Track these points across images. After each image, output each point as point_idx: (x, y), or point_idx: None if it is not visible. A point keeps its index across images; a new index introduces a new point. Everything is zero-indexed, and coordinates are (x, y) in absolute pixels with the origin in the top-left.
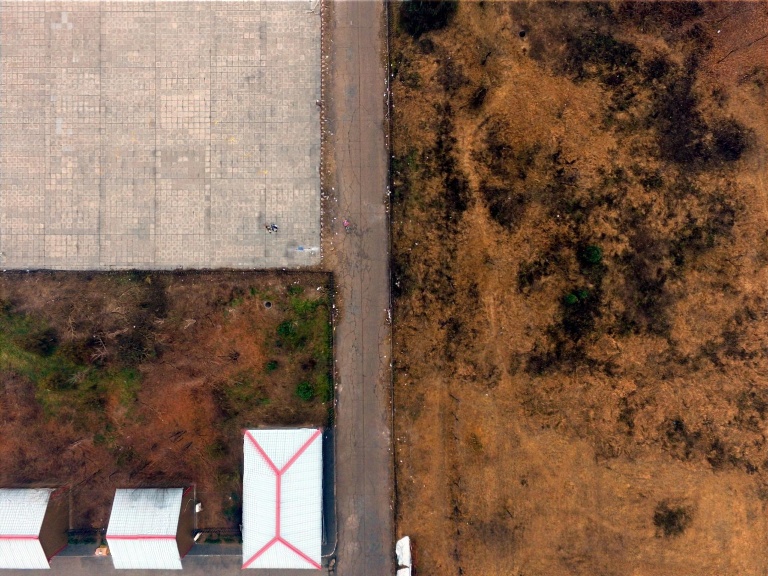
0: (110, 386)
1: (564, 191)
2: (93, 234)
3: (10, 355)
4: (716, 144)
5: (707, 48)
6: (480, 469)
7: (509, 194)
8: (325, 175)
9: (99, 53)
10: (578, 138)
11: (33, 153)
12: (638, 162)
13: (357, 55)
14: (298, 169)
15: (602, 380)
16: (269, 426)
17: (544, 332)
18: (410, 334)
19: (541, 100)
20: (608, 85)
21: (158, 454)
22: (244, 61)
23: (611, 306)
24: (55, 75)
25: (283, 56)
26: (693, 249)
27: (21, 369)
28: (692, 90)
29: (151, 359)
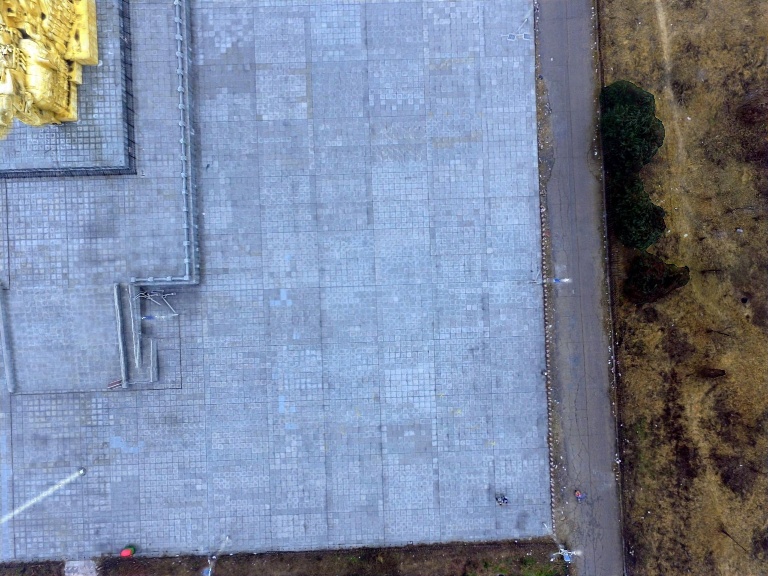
0: None
1: None
2: (320, 513)
3: None
4: None
5: None
6: None
7: (740, 461)
8: (553, 445)
9: (320, 329)
10: None
11: (256, 433)
12: None
13: (580, 323)
14: (526, 439)
15: None
16: None
17: None
18: None
19: (767, 367)
20: None
21: None
22: (467, 333)
23: None
24: (276, 353)
25: (506, 327)
26: None
27: None
28: None
29: None
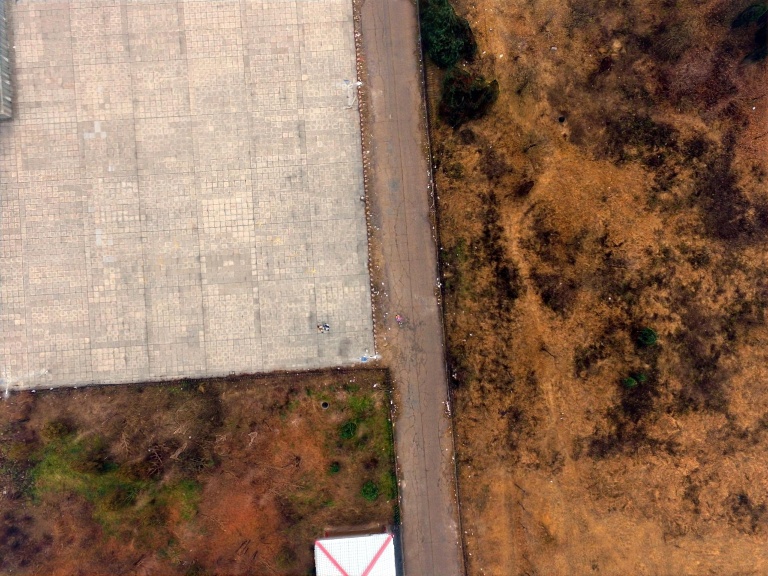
0: (169, 500)
1: (614, 273)
2: (141, 345)
3: (63, 476)
4: (759, 218)
5: (744, 125)
6: (550, 557)
7: (560, 280)
8: (374, 271)
9: (135, 161)
10: (624, 220)
11: (73, 266)
12: (684, 241)
13: (398, 148)
14: (346, 266)
15: (664, 459)
16: (335, 529)
17: (604, 415)
18: (471, 426)
19: (585, 185)
20: (650, 166)
21: (223, 567)
22: (284, 161)
23: (668, 385)
24: (91, 186)
25: (324, 154)
26: (744, 324)
27: (75, 490)
28: (732, 167)
29: (209, 469)
